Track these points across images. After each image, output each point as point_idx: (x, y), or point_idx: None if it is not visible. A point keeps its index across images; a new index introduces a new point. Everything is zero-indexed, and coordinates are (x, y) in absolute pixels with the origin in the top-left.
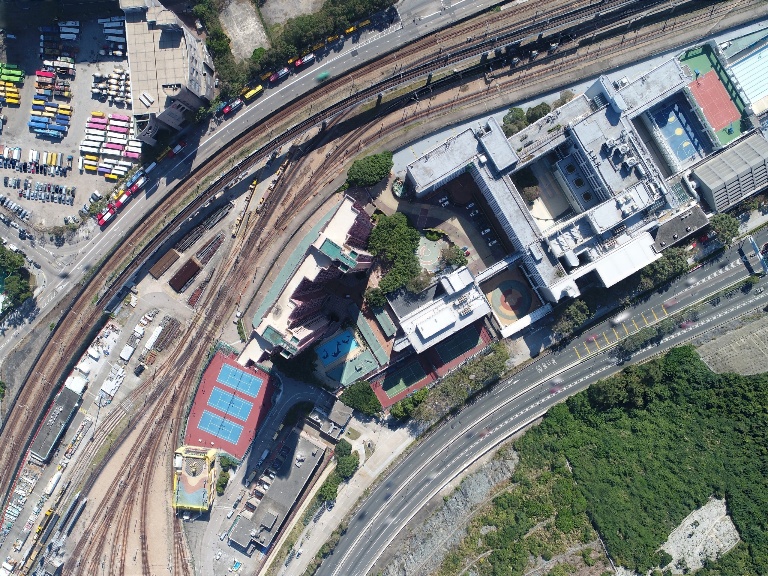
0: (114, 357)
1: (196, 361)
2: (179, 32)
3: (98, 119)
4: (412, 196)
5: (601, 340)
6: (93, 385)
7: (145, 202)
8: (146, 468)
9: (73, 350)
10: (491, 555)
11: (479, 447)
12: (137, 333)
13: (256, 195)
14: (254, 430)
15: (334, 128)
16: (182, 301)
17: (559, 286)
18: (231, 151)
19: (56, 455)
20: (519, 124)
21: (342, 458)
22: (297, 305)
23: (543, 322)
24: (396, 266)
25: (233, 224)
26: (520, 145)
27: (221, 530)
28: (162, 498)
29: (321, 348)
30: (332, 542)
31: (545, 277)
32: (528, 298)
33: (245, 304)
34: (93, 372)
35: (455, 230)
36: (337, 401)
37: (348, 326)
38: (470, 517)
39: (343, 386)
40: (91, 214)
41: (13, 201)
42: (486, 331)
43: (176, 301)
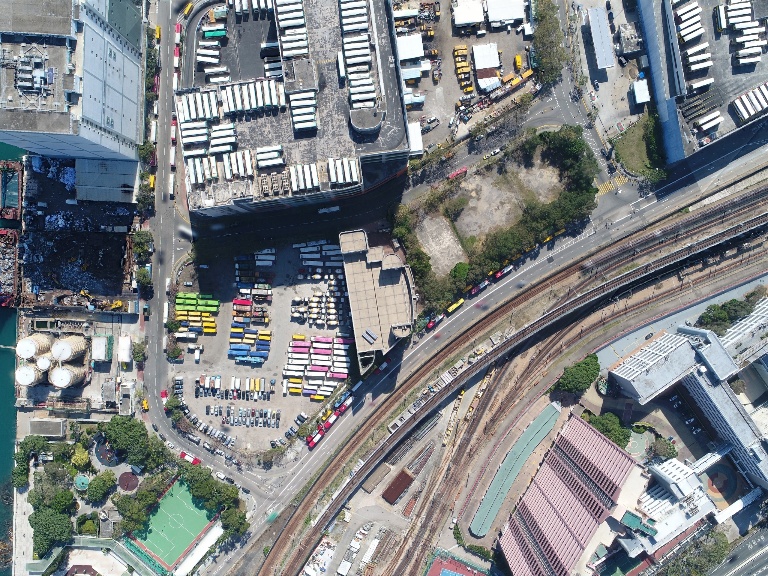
0: (331, 573)
1: (414, 569)
2: (398, 269)
3: (301, 343)
4: (616, 393)
5: None
6: None
7: (352, 419)
8: None
9: (292, 573)
10: None
11: None
12: (354, 548)
13: (463, 403)
14: None
15: (536, 333)
16: (396, 512)
17: None
18: (435, 363)
19: None
20: (725, 326)
21: None
22: None
23: None
24: None
25: (442, 433)
26: (735, 352)
27: None
28: None
29: None
30: None
31: (767, 474)
32: (734, 480)
33: (459, 509)
34: None
35: (660, 421)
36: None
37: None
38: None
39: None
40: (299, 436)
41: (216, 429)
42: None
43: (390, 513)
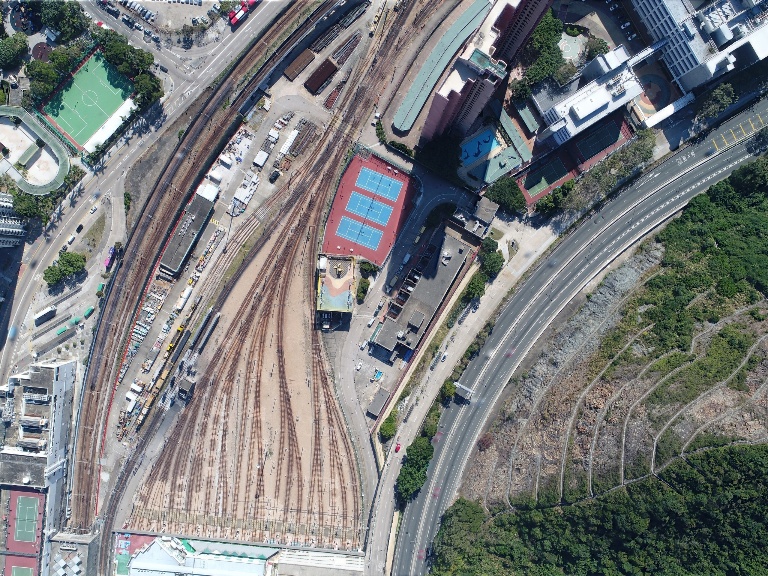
0: (247, 164)
1: (333, 166)
2: None
3: None
4: None
5: (738, 132)
6: (225, 194)
7: (278, 1)
8: (282, 279)
9: (206, 155)
10: (655, 327)
11: (621, 242)
12: (272, 137)
13: None
14: (394, 235)
15: None
16: (318, 103)
17: (714, 59)
18: None
19: (186, 269)
20: None
21: (489, 254)
22: (498, 35)
23: (682, 115)
24: (543, 55)
25: (370, 22)
26: None
27: (361, 340)
28: (299, 309)
29: (462, 148)
30: (481, 340)
31: (698, 54)
32: (667, 92)
33: (383, 105)
34: (225, 180)
35: (595, 25)
36: (483, 197)
37: (493, 120)
38: (622, 303)
39: (486, 185)
40: (222, 13)
41: (136, 2)
42: (626, 126)
43: (312, 104)
